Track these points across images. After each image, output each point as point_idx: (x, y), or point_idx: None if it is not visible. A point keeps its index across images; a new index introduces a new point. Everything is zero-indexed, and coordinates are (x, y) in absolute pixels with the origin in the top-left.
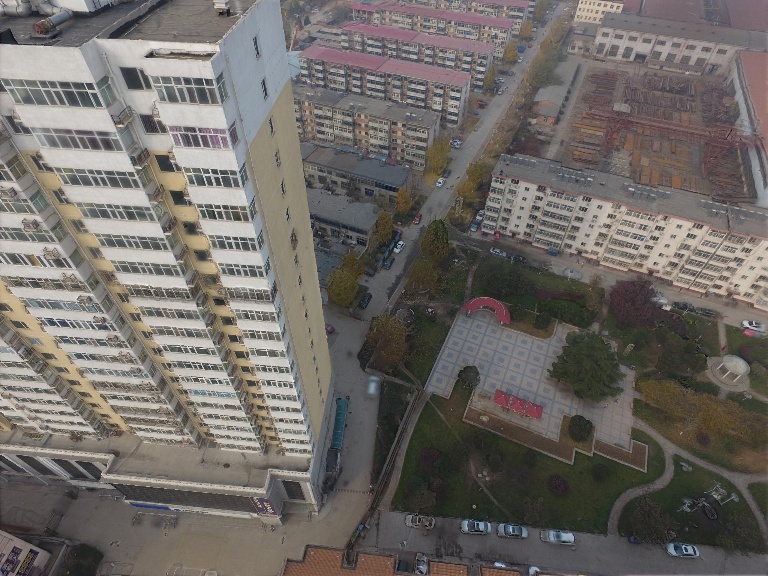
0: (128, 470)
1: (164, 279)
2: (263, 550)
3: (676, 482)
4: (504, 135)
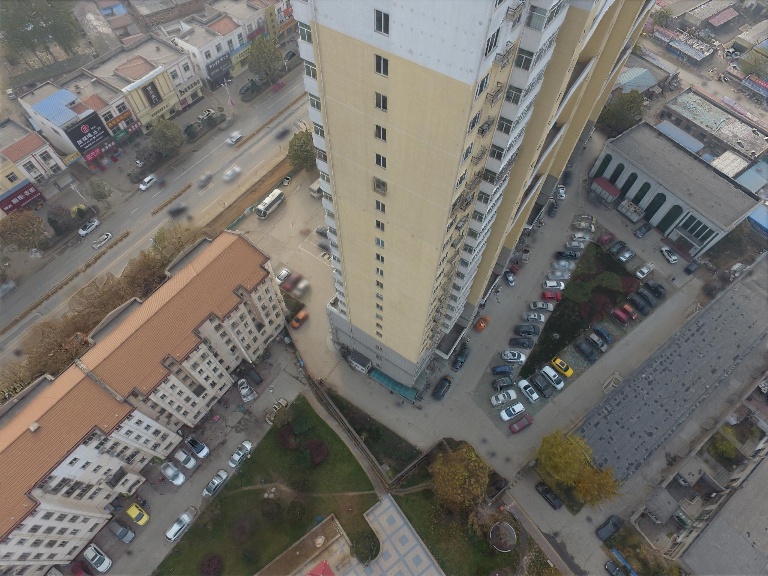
0: None
1: None
2: None
3: None
4: None
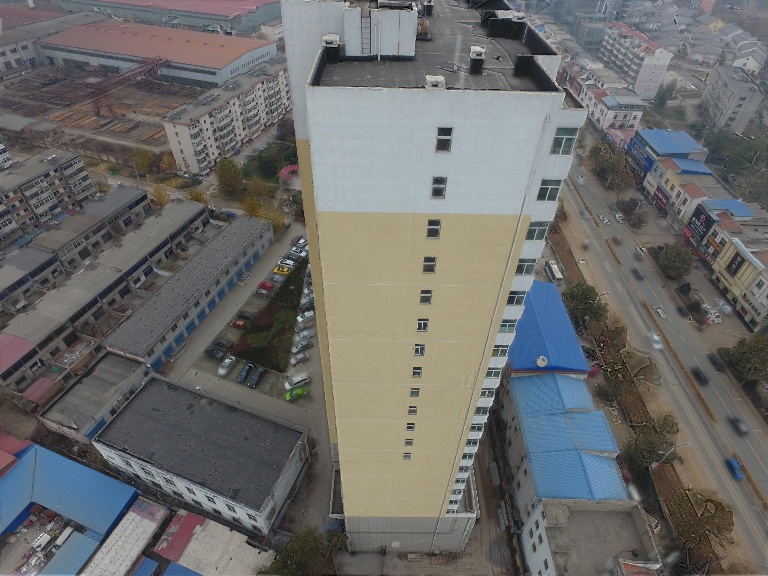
0: None
1: None
2: None
3: None
4: None
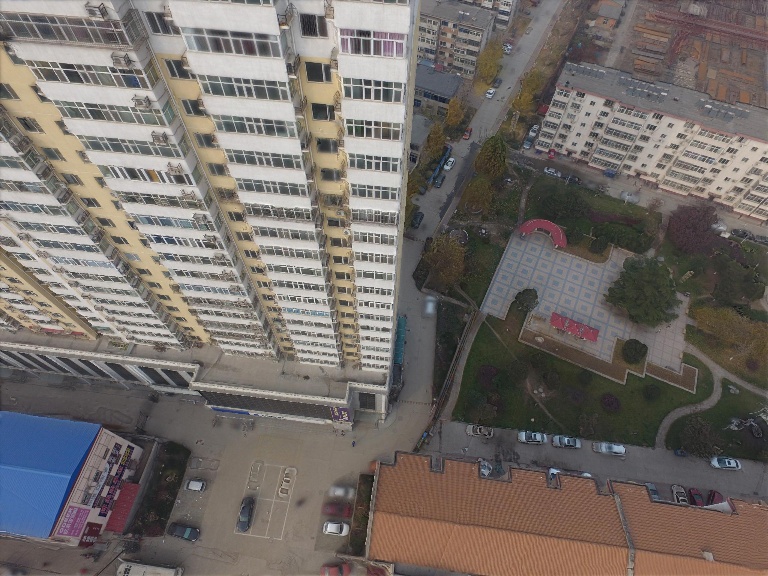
0: (214, 379)
1: (288, 199)
2: (336, 451)
3: (723, 403)
4: (559, 39)
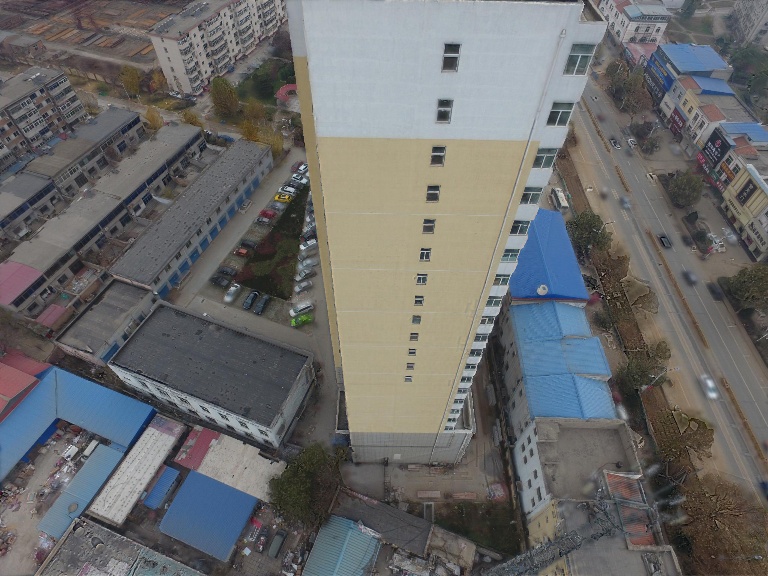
0: None
1: None
2: None
3: None
4: None
